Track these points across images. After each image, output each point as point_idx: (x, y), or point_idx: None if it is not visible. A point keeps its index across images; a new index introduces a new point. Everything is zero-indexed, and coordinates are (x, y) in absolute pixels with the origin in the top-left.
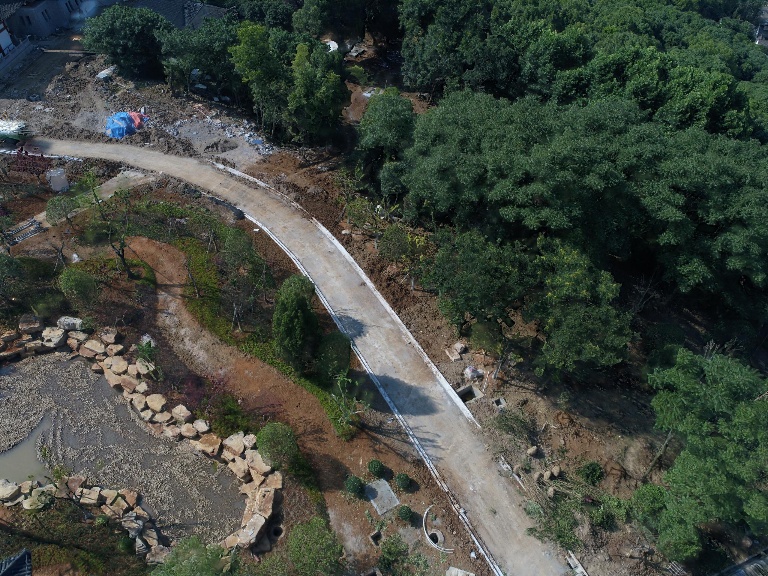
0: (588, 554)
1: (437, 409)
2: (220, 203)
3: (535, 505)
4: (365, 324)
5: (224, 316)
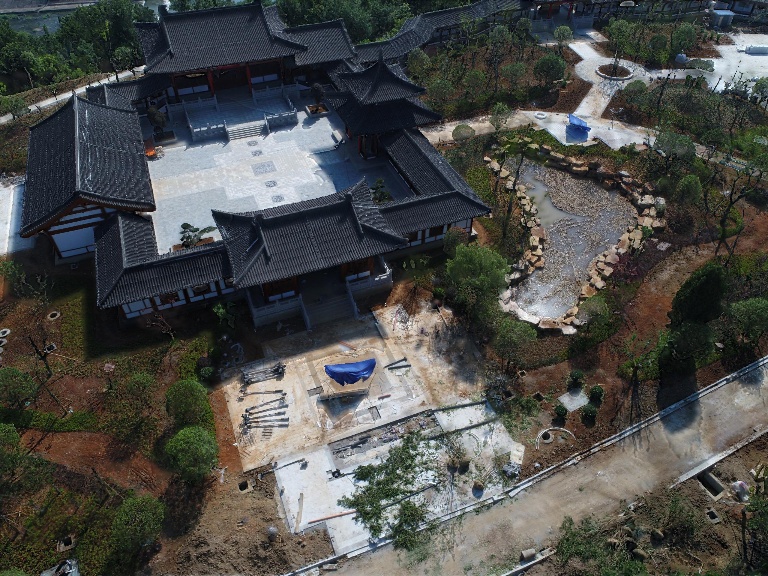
0: (556, 569)
1: (679, 451)
2: None
3: (596, 527)
4: (761, 391)
5: None
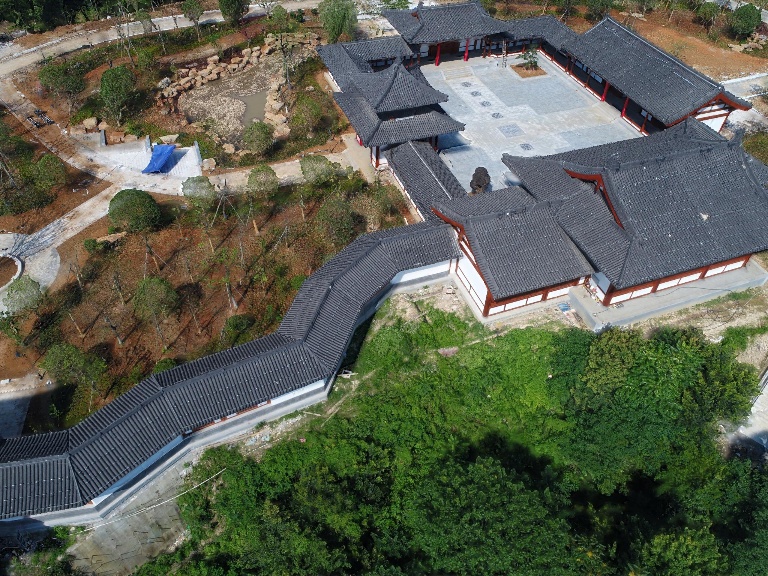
0: None
1: None
2: (68, 53)
3: None
4: None
5: (186, 43)
